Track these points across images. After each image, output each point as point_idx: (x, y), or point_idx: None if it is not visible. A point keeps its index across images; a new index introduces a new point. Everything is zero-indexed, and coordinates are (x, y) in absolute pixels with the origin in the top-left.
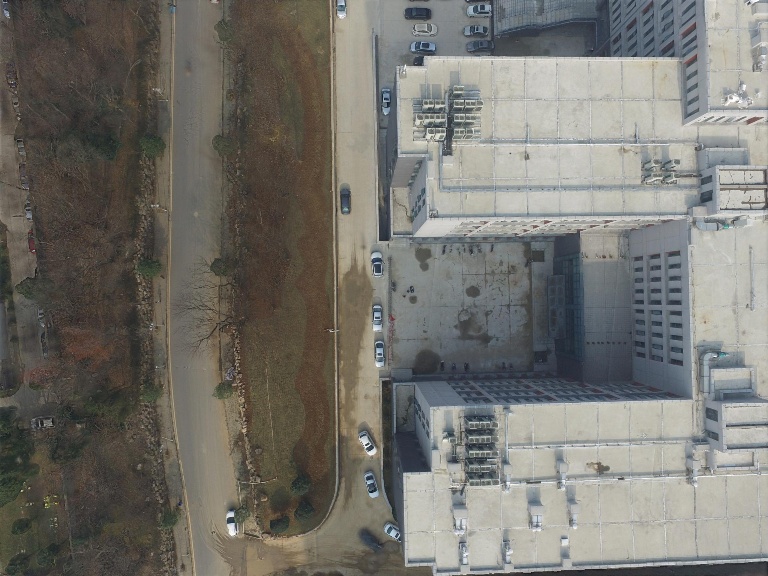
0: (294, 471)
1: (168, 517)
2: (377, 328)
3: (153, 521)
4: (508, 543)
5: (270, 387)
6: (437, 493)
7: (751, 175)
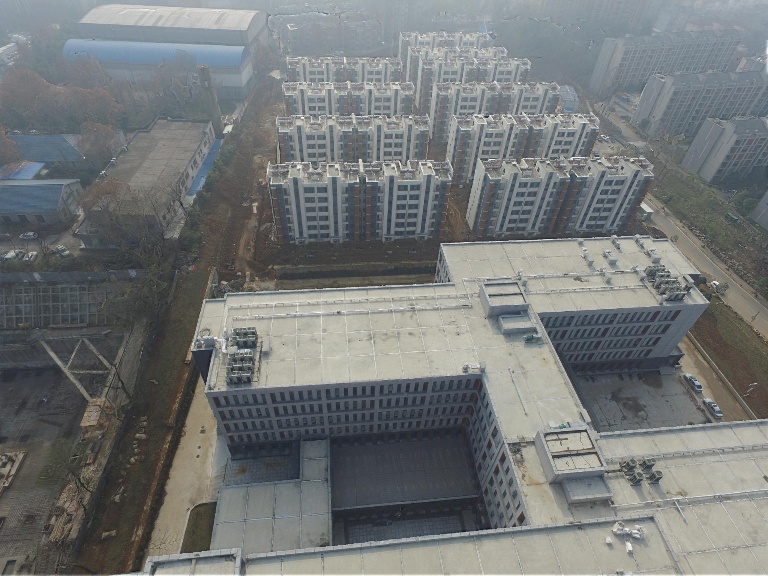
0: (707, 309)
1: (767, 283)
2: (708, 400)
3: (767, 286)
4: (618, 248)
5: (762, 353)
6: (672, 267)
7: (568, 465)
